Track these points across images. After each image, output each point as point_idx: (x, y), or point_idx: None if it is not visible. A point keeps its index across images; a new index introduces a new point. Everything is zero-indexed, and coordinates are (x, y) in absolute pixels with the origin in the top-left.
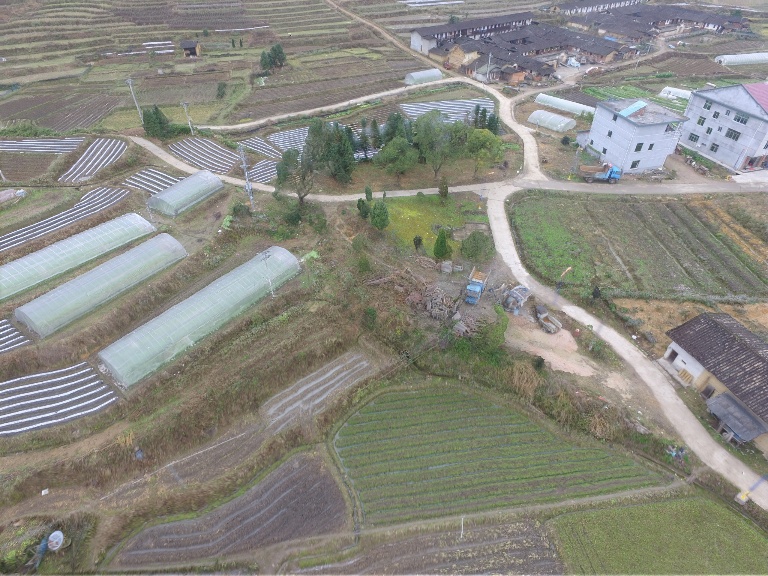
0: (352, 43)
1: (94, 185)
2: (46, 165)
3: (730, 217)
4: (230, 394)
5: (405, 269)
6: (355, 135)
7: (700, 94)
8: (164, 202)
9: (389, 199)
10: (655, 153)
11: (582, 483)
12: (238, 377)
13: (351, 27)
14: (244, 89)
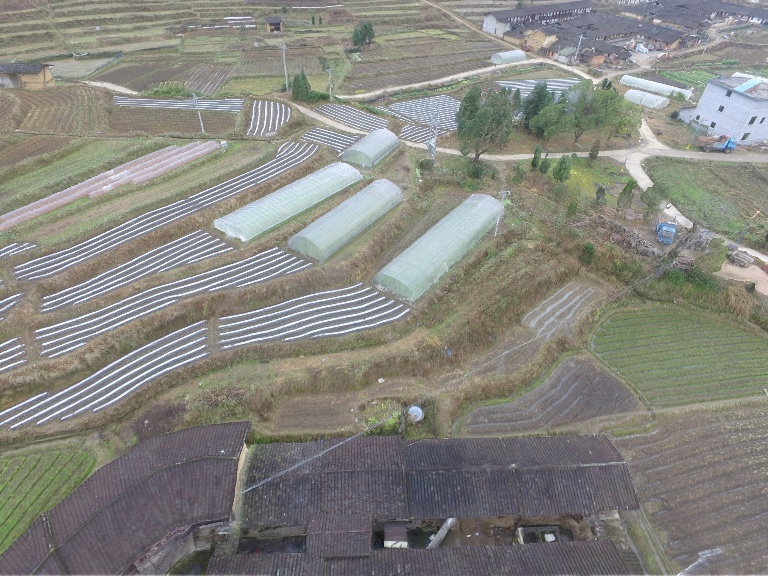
0: (426, 24)
1: (282, 140)
2: (228, 121)
3: None
4: (502, 308)
5: (598, 215)
6: None
7: None
8: (363, 154)
9: None
10: (764, 127)
11: None
12: (499, 296)
13: (420, 9)
14: (344, 63)
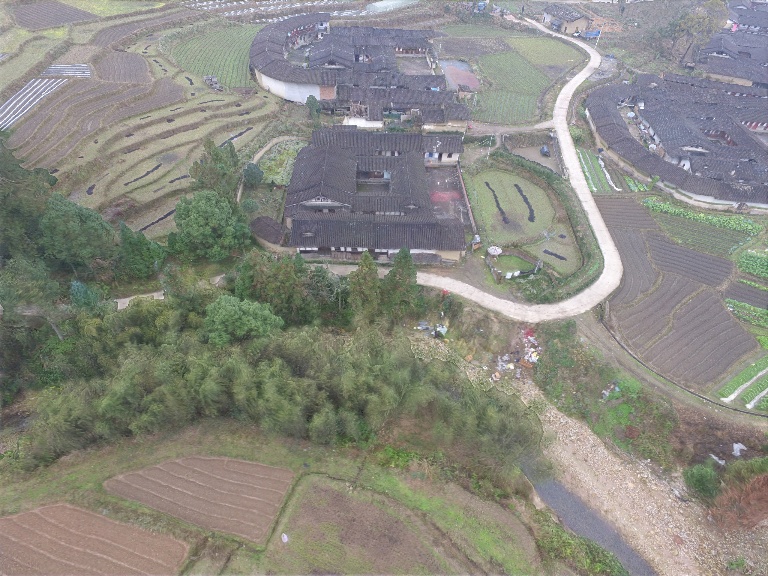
0: None
1: None
2: None
3: (583, 7)
4: (410, 16)
5: (457, 2)
6: None
7: None
8: None
9: None
10: None
11: None
12: None
13: None
14: None
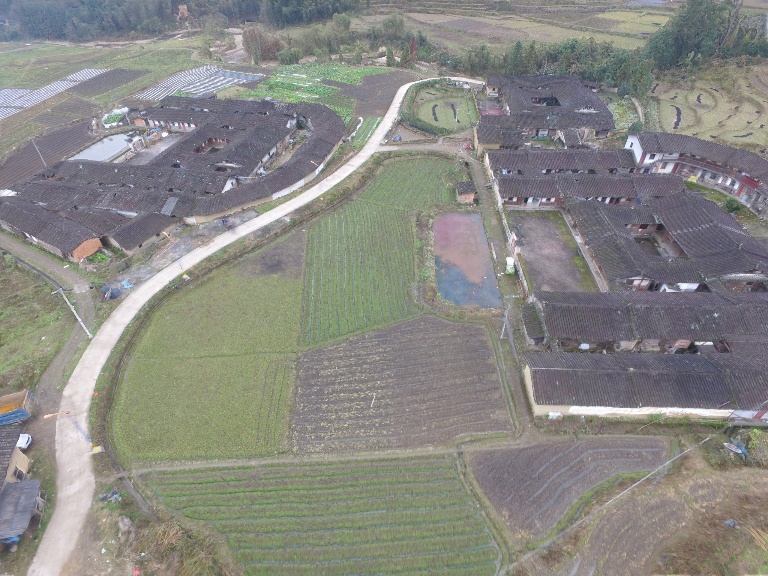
0: None
1: None
2: None
3: None
4: None
5: None
6: None
7: None
8: None
9: None
10: None
11: (232, 481)
12: None
13: None
14: None
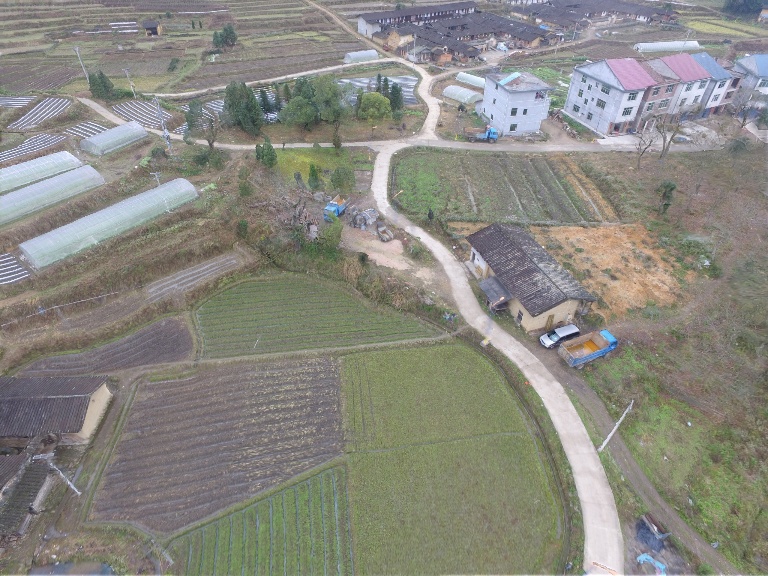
0: (304, 27)
1: (37, 132)
2: None
3: (578, 169)
4: (119, 275)
5: (282, 196)
6: (270, 97)
7: (579, 69)
8: (92, 144)
9: (289, 148)
10: (530, 118)
11: (374, 336)
12: (128, 265)
13: (306, 12)
14: (195, 64)
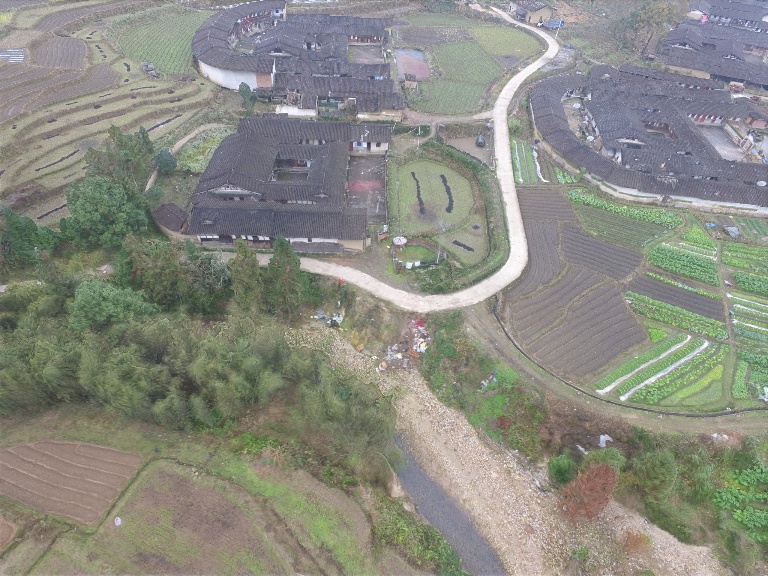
0: None
1: None
2: None
3: None
4: (373, 4)
5: None
6: None
7: None
8: None
9: None
10: None
11: None
12: None
13: None
14: None
